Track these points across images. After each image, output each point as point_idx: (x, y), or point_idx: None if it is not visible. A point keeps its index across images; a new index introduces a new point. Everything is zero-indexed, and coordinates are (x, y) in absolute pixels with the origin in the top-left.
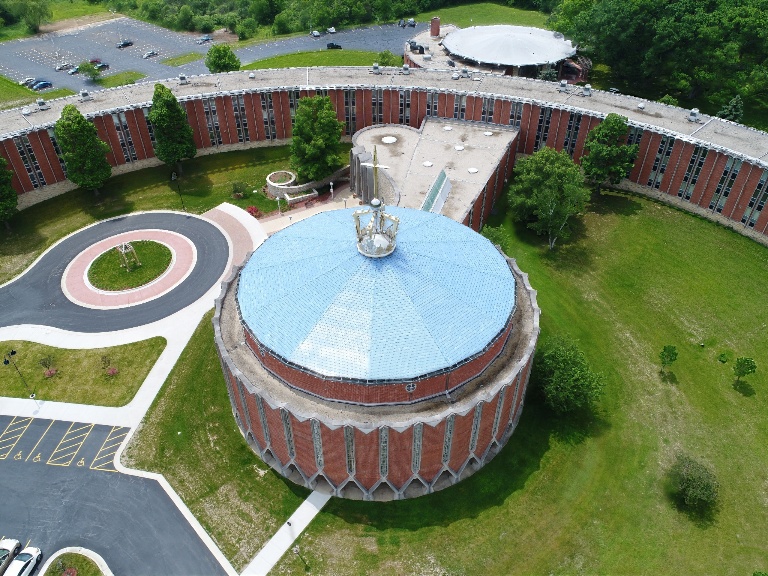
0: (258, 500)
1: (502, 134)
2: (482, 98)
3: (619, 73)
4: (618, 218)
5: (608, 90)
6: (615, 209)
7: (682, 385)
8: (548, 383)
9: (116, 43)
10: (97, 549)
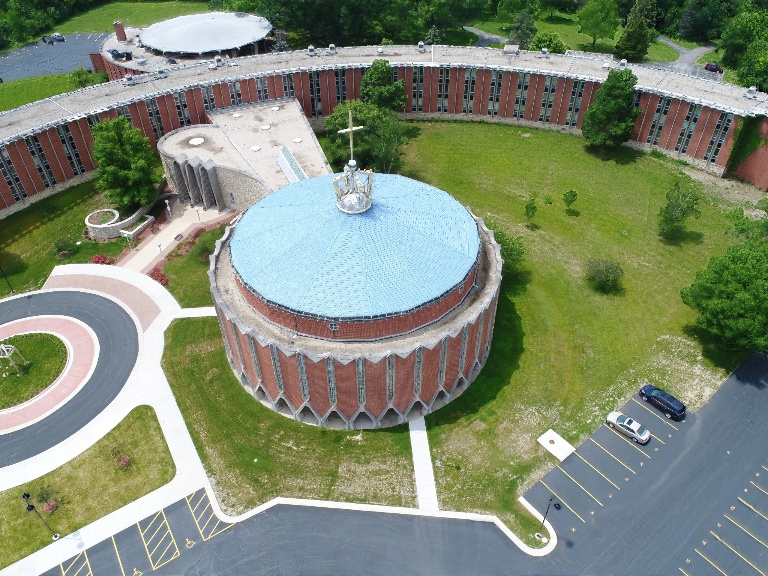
0: (377, 456)
1: (286, 106)
2: (254, 79)
3: (311, 35)
4: (412, 142)
5: None
6: None
7: (544, 227)
8: None
9: None
10: None
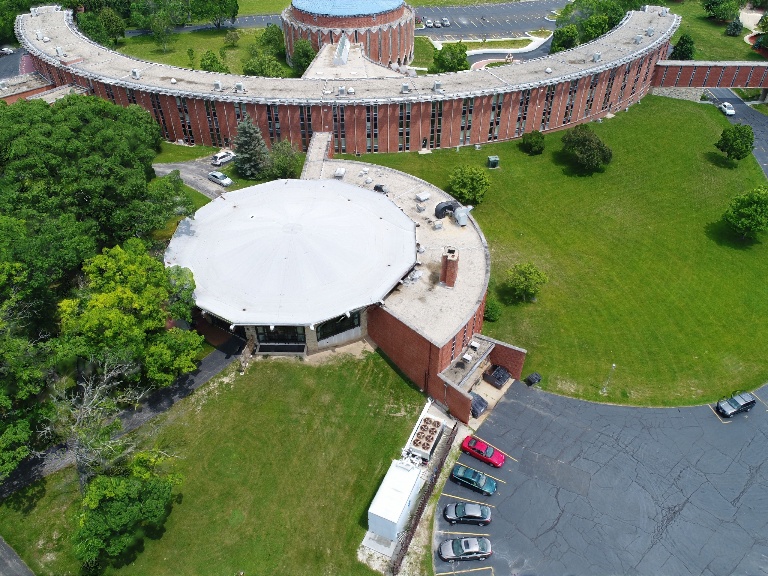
0: None
1: None
2: None
3: None
4: None
5: None
6: None
7: None
8: None
9: None
10: None
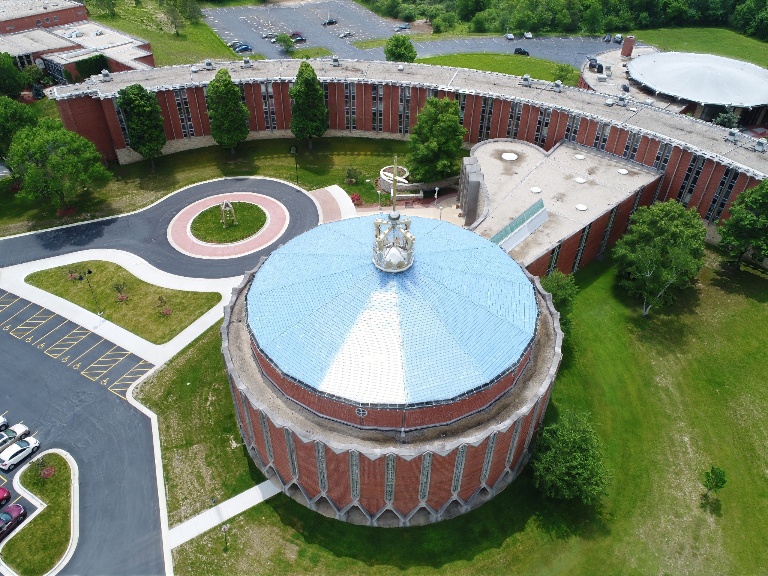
0: (218, 469)
1: (639, 175)
2: (628, 131)
3: None
4: (746, 302)
5: None
6: (748, 290)
7: (724, 520)
8: (540, 459)
9: (324, 20)
10: (78, 459)
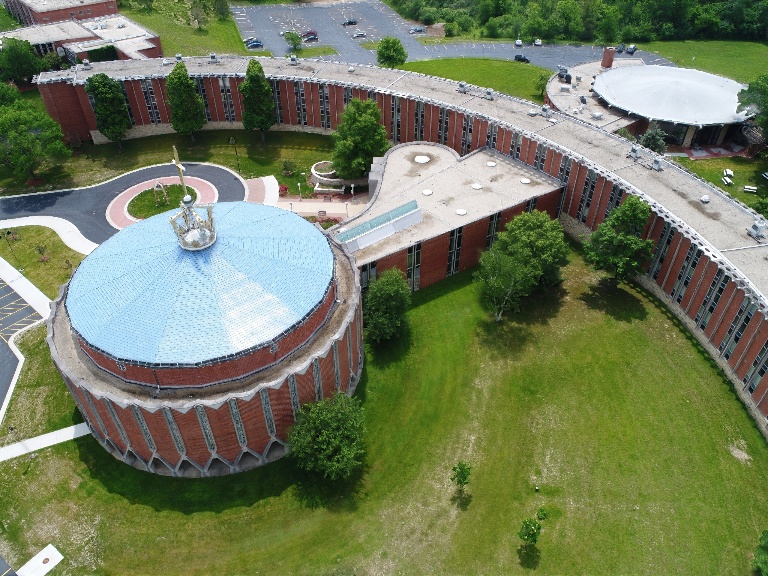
0: (50, 408)
1: (540, 186)
2: (536, 142)
3: None
4: (602, 318)
5: (761, 174)
6: (611, 308)
7: (466, 514)
8: None
9: None
10: None
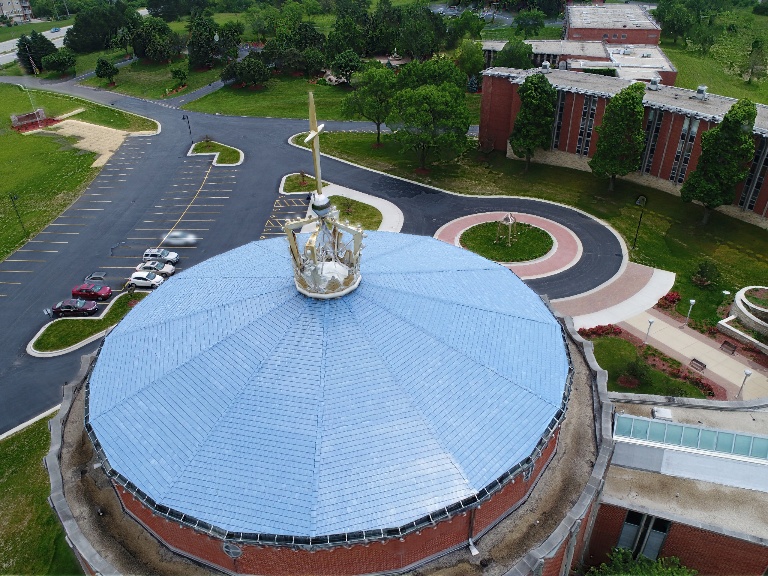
0: None
1: None
2: None
3: None
4: None
5: None
6: None
7: None
8: None
9: None
10: None
